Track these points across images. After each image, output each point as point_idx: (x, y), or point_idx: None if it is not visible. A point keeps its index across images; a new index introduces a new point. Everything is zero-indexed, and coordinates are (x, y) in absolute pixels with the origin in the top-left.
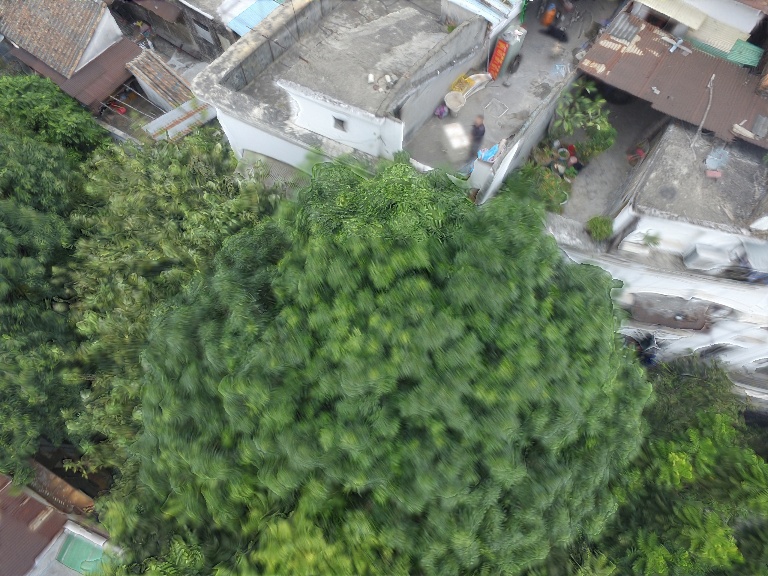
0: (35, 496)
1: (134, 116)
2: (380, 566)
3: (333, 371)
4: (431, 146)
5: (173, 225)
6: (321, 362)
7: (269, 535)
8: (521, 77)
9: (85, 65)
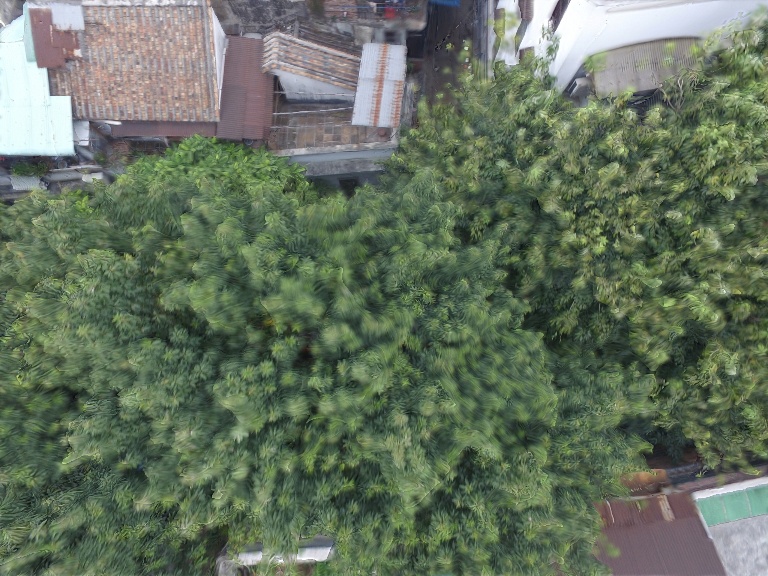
0: None
1: None
2: None
3: None
4: None
5: (714, 155)
6: None
7: None
8: None
9: (220, 95)
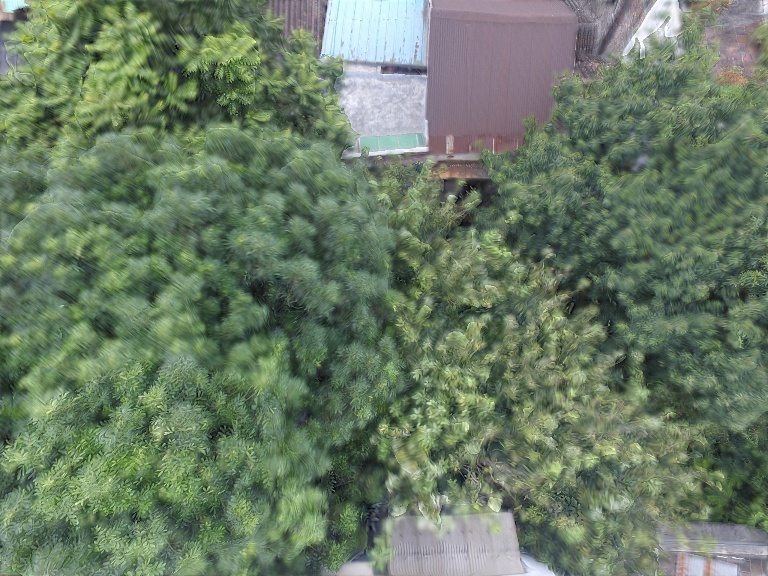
0: (470, 156)
1: None
2: (41, 136)
3: (99, 224)
4: None
5: (482, 374)
6: (121, 231)
7: (129, 104)
8: None
9: None
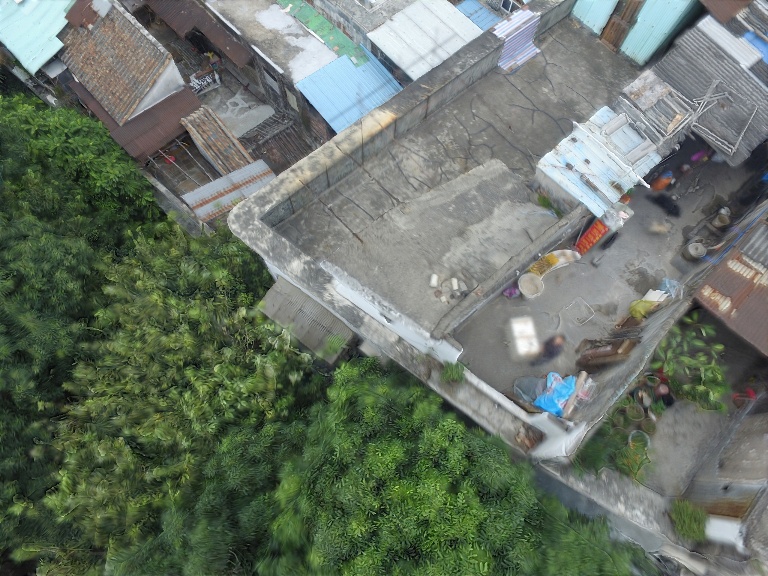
0: None
1: (182, 167)
2: None
3: None
4: (491, 333)
5: (175, 393)
6: None
7: None
8: (615, 255)
9: (140, 113)
